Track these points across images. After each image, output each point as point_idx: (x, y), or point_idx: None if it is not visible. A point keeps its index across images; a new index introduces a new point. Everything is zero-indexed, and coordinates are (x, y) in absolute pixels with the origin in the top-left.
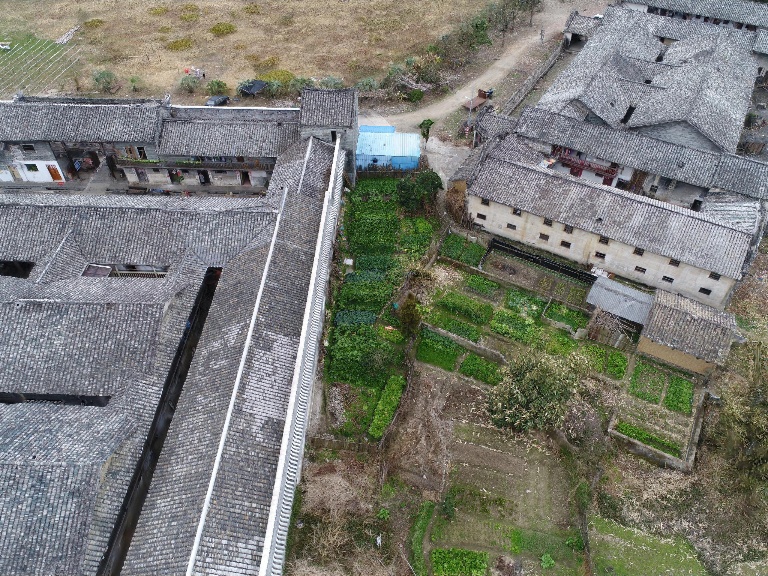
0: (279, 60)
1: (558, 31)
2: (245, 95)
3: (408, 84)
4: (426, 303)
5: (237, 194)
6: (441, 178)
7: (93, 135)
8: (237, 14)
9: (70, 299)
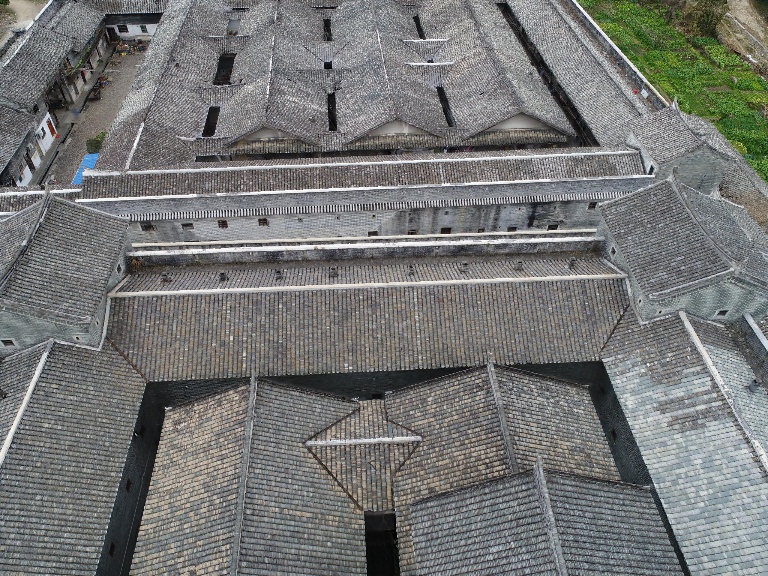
0: None
1: None
2: None
3: None
4: None
5: (109, 62)
6: None
7: (55, 60)
8: None
9: None
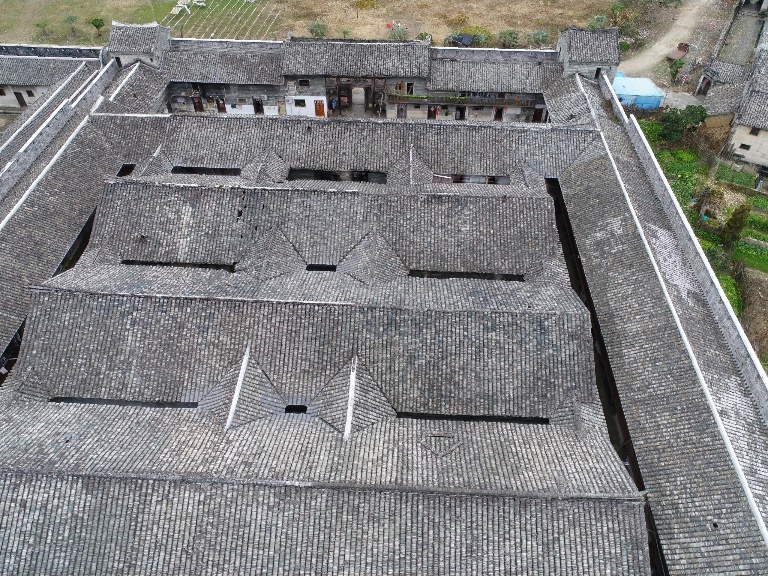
0: (467, 18)
1: None
2: None
3: None
4: (721, 219)
5: None
6: None
7: (372, 70)
8: None
9: None
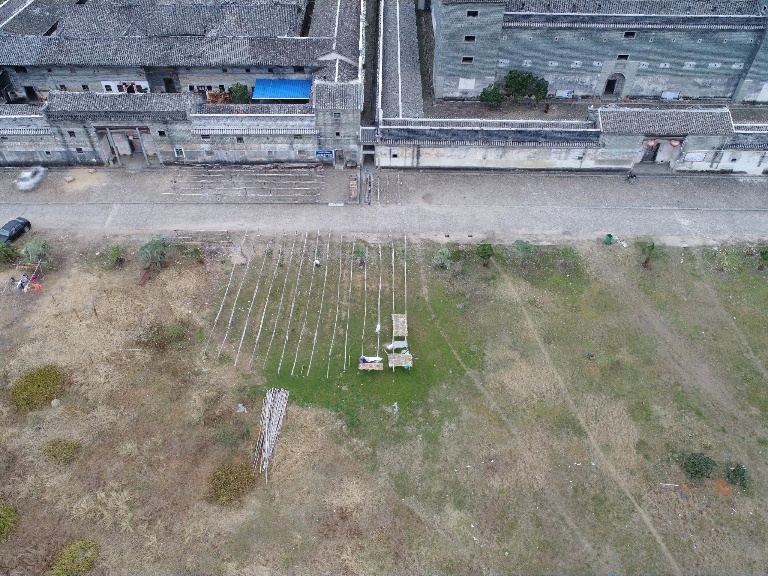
0: None
1: None
2: None
3: None
4: None
5: None
6: None
7: None
8: None
9: (108, 7)
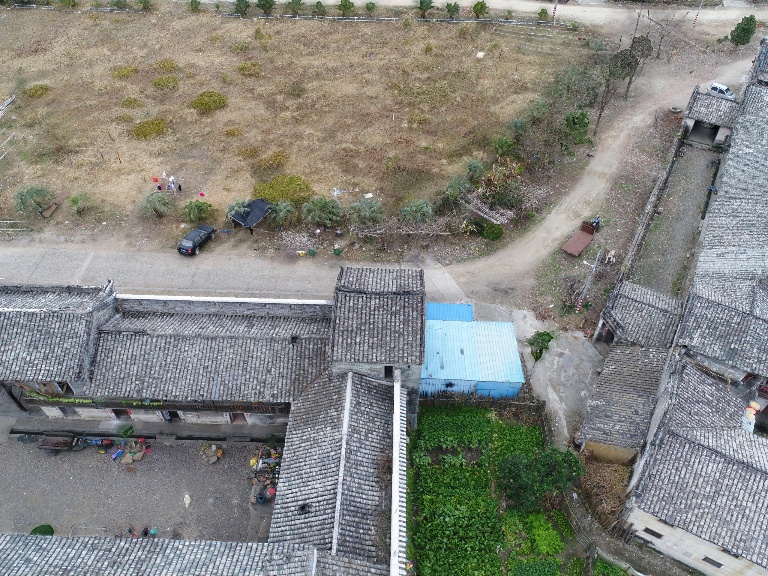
0: (287, 157)
1: (664, 107)
2: (238, 223)
3: (477, 210)
4: None
5: (224, 441)
6: (553, 406)
7: None
8: (229, 77)
9: None
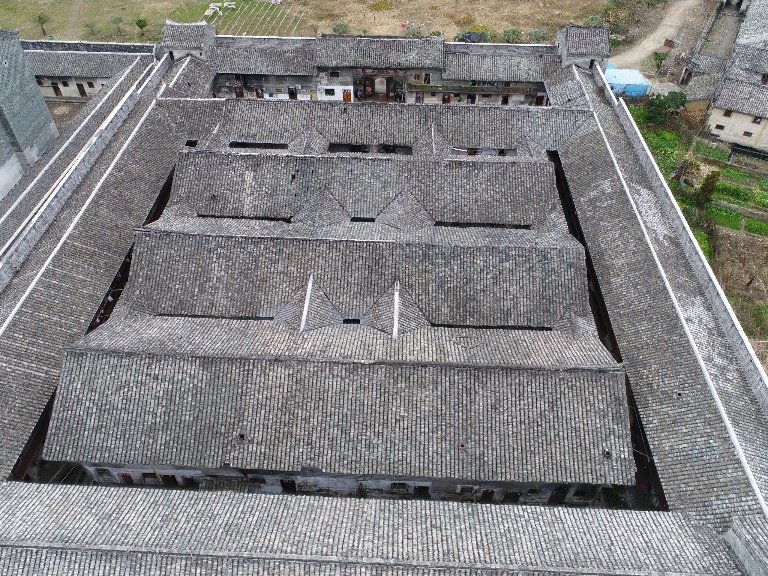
0: (474, 18)
1: None
2: None
3: None
4: (698, 187)
5: None
6: None
7: (394, 62)
8: None
9: None
